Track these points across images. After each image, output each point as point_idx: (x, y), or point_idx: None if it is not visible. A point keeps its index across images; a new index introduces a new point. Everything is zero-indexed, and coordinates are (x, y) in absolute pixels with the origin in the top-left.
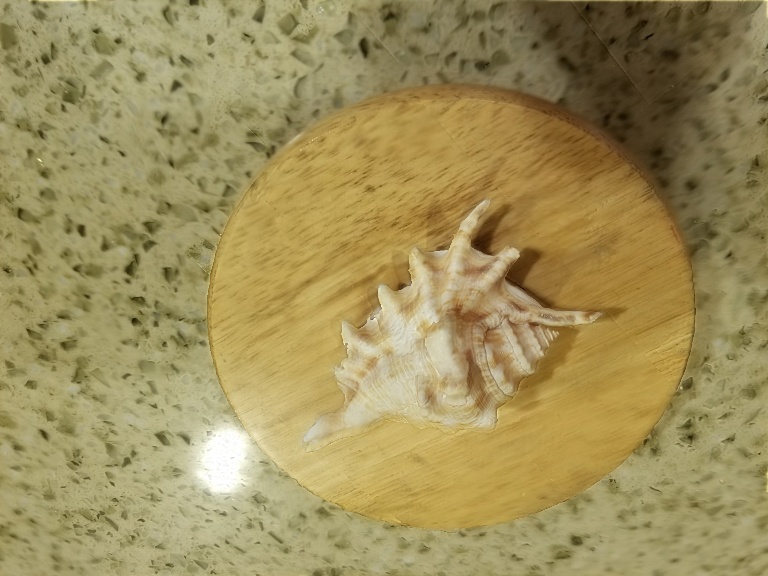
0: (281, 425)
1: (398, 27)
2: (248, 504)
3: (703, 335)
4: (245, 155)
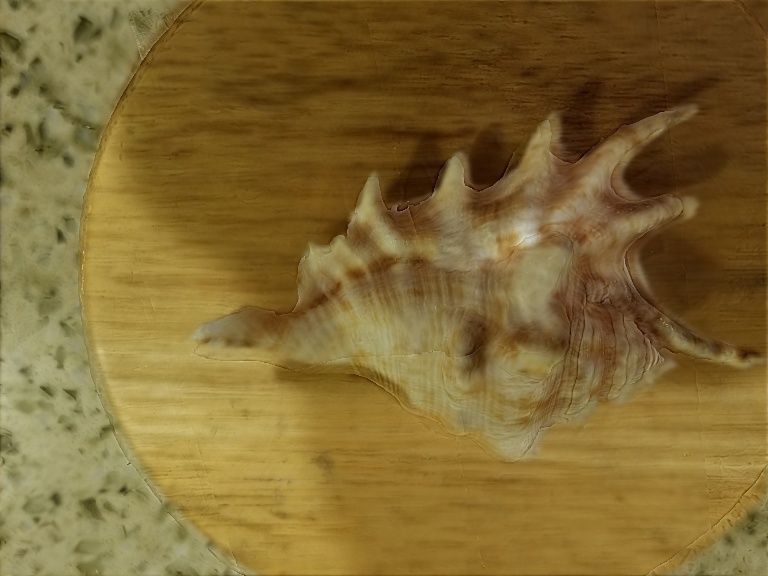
0: (146, 313)
1: None
2: None
3: None
4: None
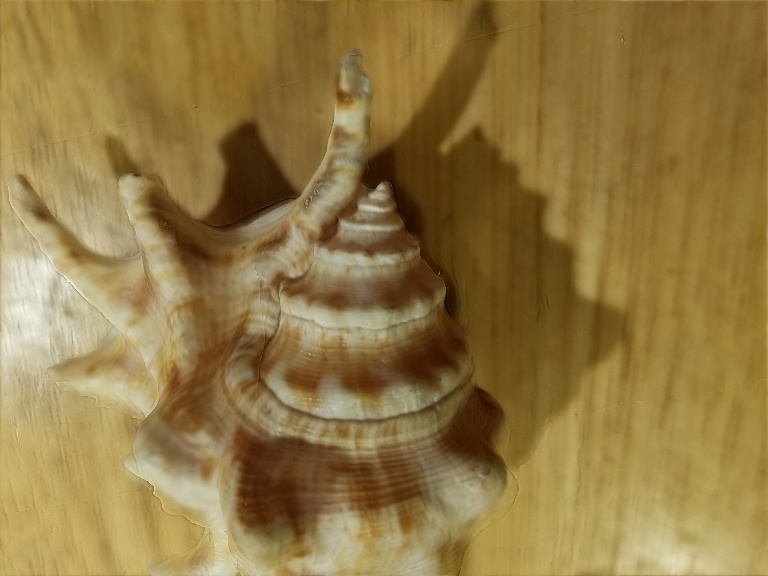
0: None
1: None
2: None
3: None
4: None
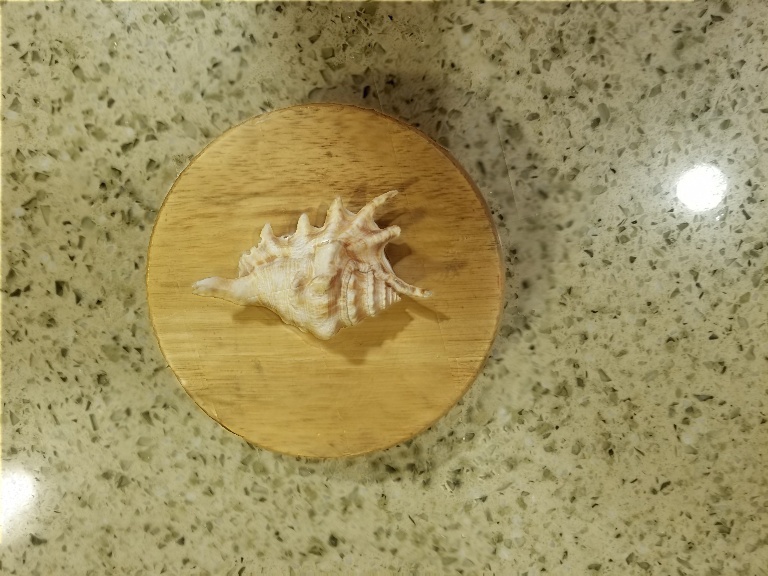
0: (176, 289)
1: (392, 91)
2: (90, 380)
3: (494, 401)
4: (254, 114)
